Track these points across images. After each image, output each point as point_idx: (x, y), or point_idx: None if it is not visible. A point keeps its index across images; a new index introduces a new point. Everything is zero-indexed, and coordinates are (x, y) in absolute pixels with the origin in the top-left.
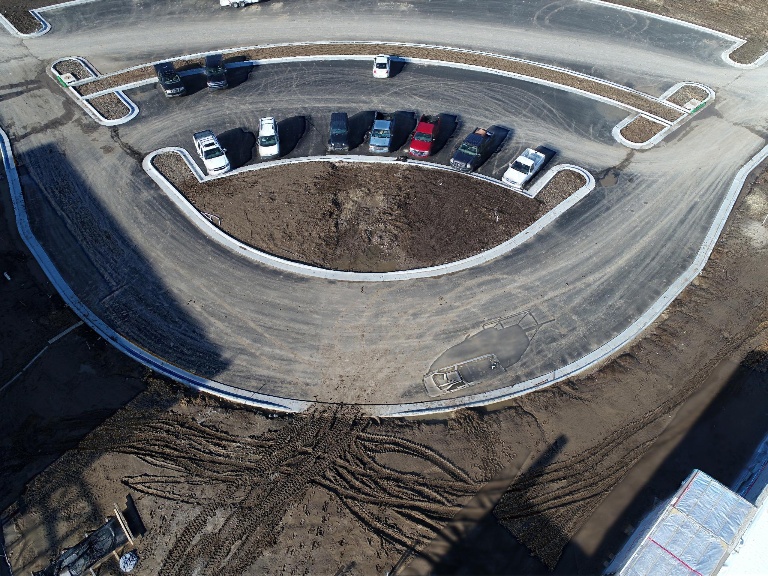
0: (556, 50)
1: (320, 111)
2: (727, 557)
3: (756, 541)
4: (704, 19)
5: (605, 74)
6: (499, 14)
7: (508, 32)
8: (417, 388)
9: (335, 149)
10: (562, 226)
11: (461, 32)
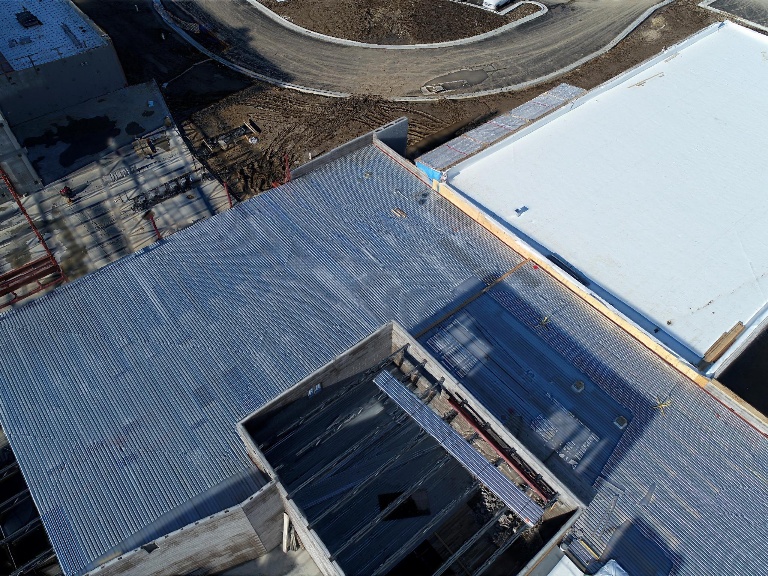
0: None
1: None
2: (567, 104)
3: (587, 108)
4: None
5: None
6: None
7: None
8: (416, 91)
9: None
10: (520, 29)
11: None
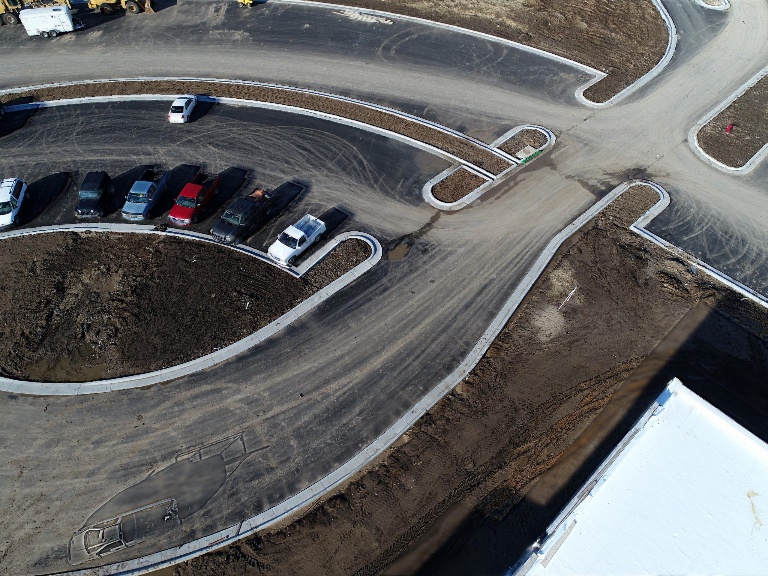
0: (392, 87)
1: (91, 166)
2: None
3: None
4: (567, 48)
5: (438, 116)
6: (342, 43)
7: (345, 65)
8: (58, 552)
9: (83, 217)
10: (323, 314)
11: (292, 65)
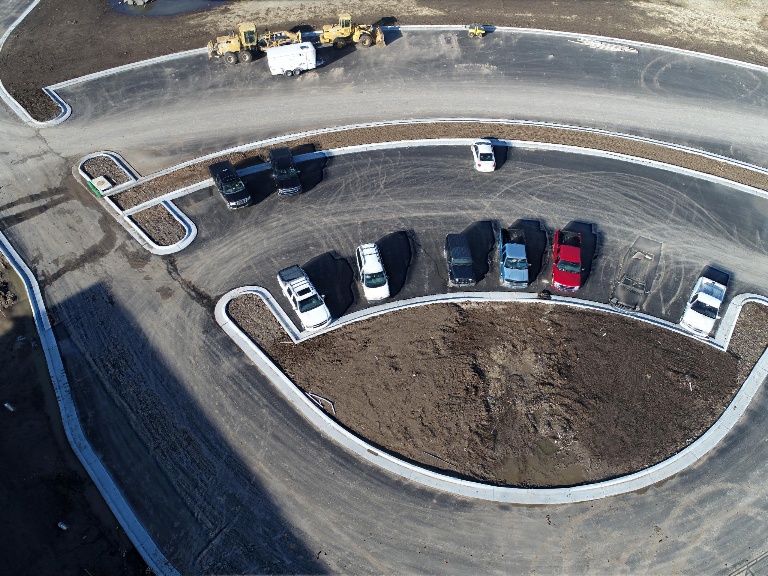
0: (680, 123)
1: (423, 223)
2: None
3: None
4: None
5: (748, 156)
6: (599, 76)
7: (617, 100)
8: None
9: (460, 286)
10: None
11: (562, 102)
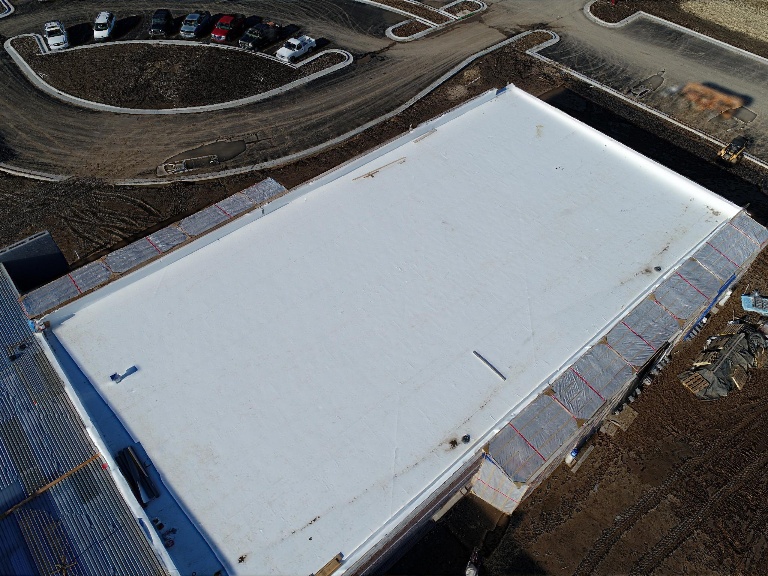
0: None
1: None
2: (253, 210)
3: (288, 212)
4: None
5: None
6: None
7: None
8: (150, 171)
9: (154, 34)
10: (310, 86)
11: None
